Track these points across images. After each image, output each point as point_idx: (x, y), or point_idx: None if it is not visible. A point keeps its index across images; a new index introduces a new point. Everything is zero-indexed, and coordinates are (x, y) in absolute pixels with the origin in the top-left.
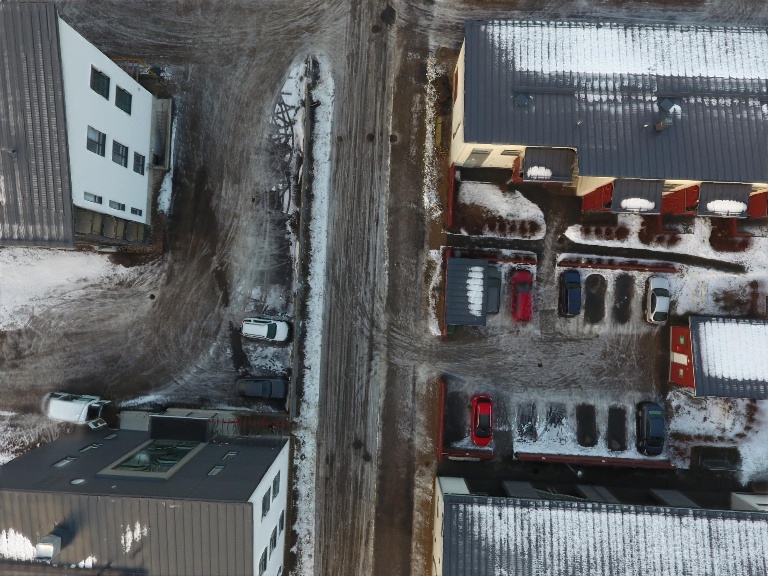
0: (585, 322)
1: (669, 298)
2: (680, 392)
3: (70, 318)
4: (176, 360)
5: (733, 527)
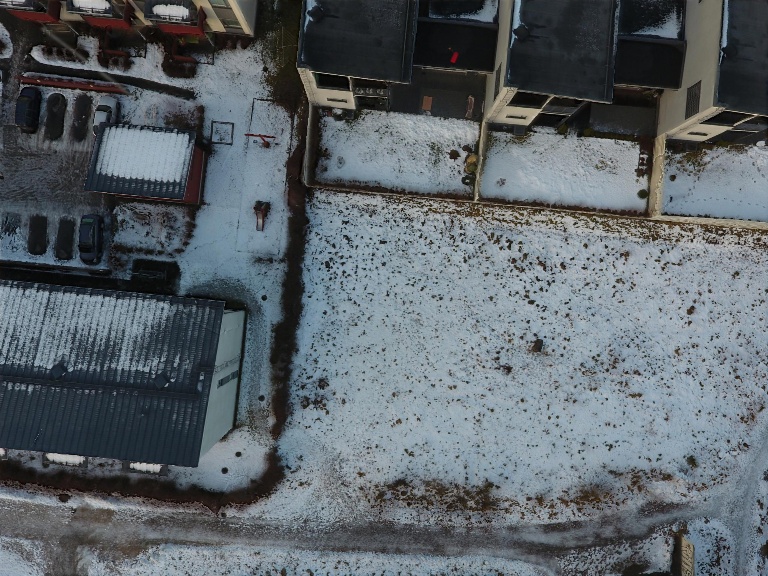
0: (45, 138)
1: (107, 113)
2: (126, 207)
3: None
4: None
5: (70, 300)
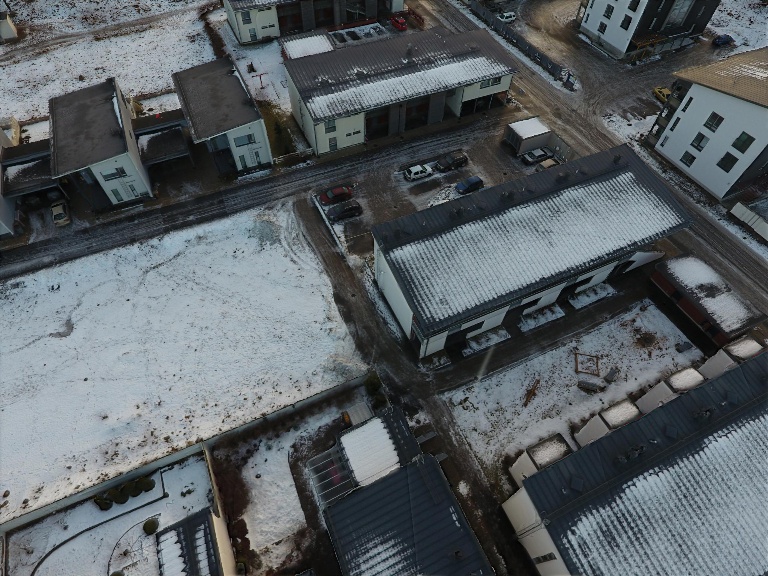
0: None
1: None
2: None
3: (578, 4)
4: (529, 7)
5: None
